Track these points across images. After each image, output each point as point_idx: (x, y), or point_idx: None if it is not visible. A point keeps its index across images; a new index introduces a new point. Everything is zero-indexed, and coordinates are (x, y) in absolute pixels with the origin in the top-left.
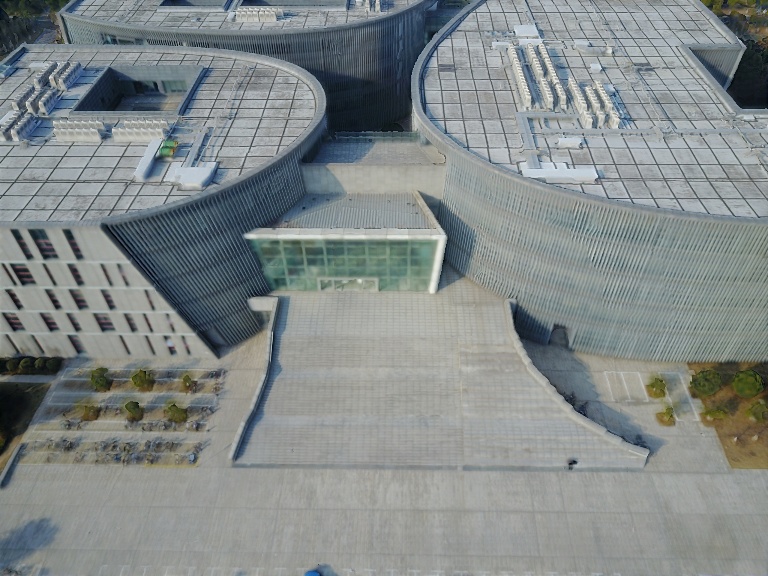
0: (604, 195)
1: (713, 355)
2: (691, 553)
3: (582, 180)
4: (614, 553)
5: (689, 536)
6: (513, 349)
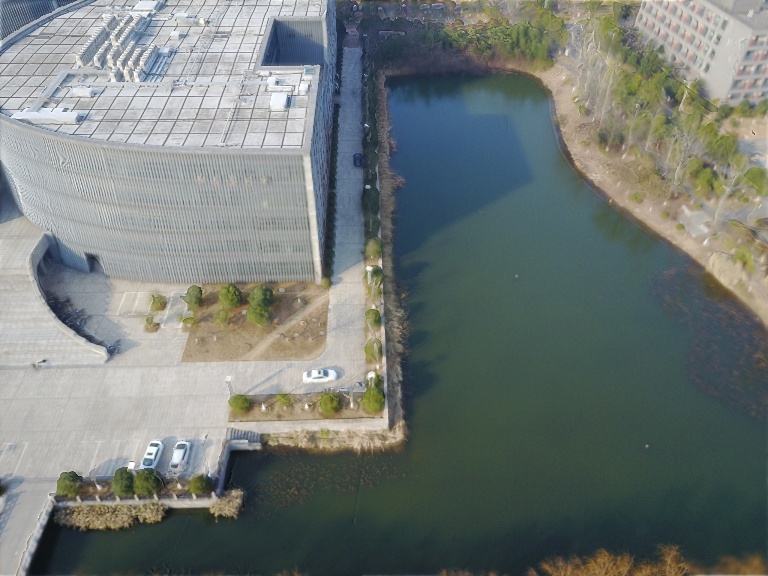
0: (71, 132)
1: (221, 276)
2: (99, 425)
3: (65, 121)
4: (33, 428)
5: (107, 413)
6: (27, 272)
